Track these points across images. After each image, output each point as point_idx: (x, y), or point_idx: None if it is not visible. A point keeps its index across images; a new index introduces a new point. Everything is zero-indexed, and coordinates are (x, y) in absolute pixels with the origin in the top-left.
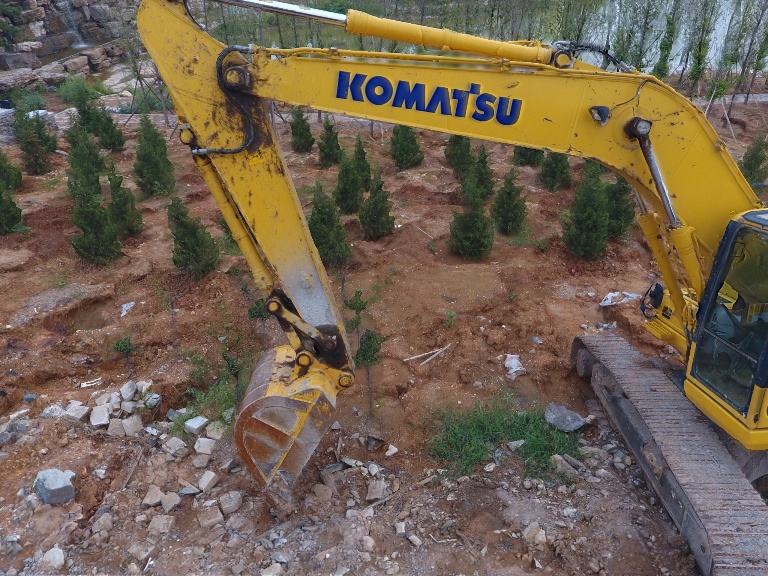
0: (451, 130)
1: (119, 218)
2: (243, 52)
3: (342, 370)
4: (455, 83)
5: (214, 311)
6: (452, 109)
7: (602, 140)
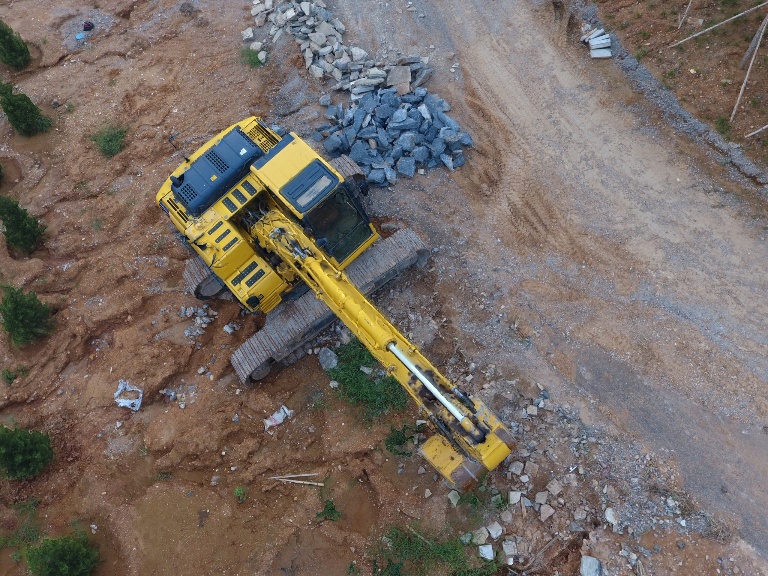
0: None
1: None
2: (439, 421)
3: None
4: None
5: None
6: None
7: None
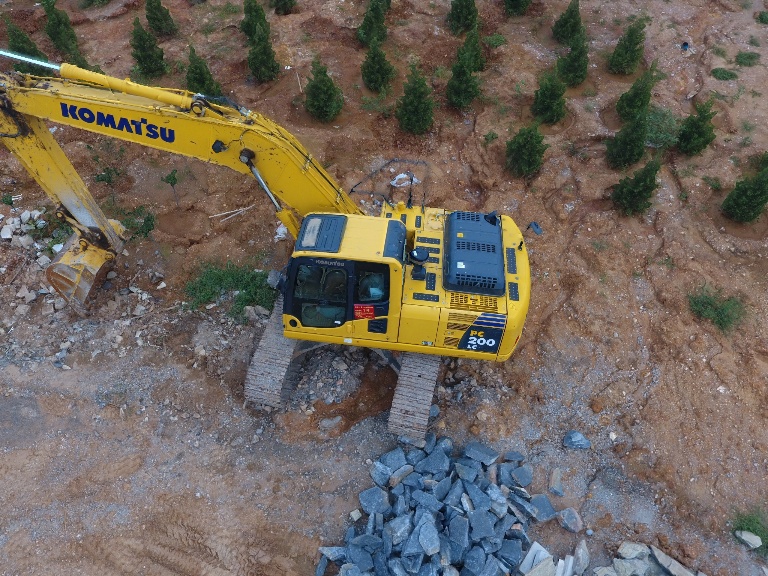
0: (136, 141)
1: (56, 37)
2: None
3: (107, 250)
4: (131, 116)
5: (107, 147)
6: (133, 130)
7: (229, 157)
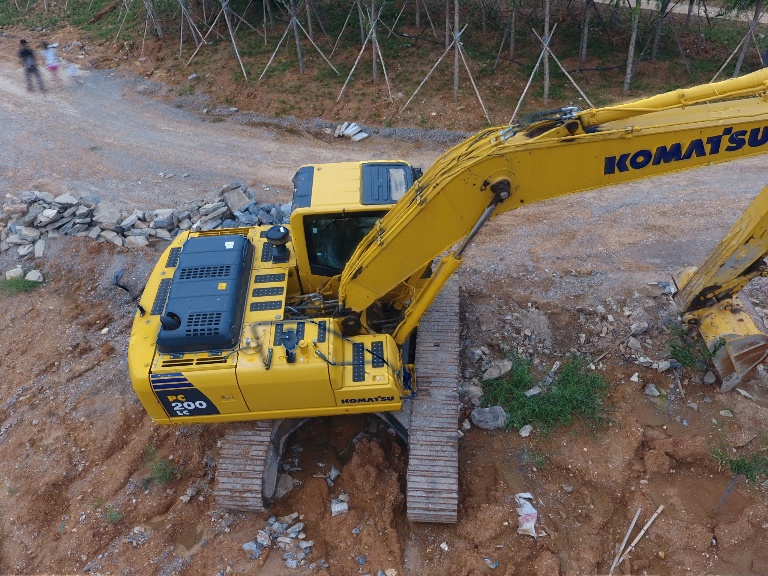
0: None
1: None
2: None
3: None
4: None
5: None
6: None
7: None
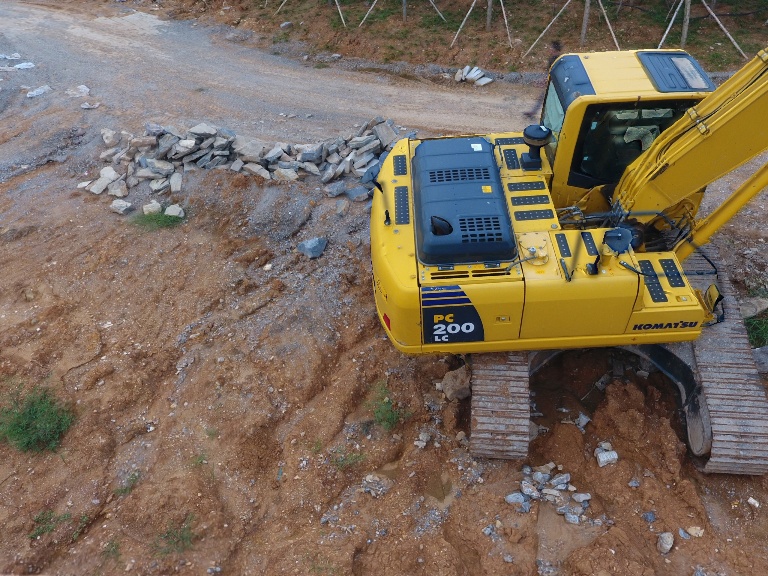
0: None
1: None
2: None
3: None
4: None
5: None
6: None
7: None
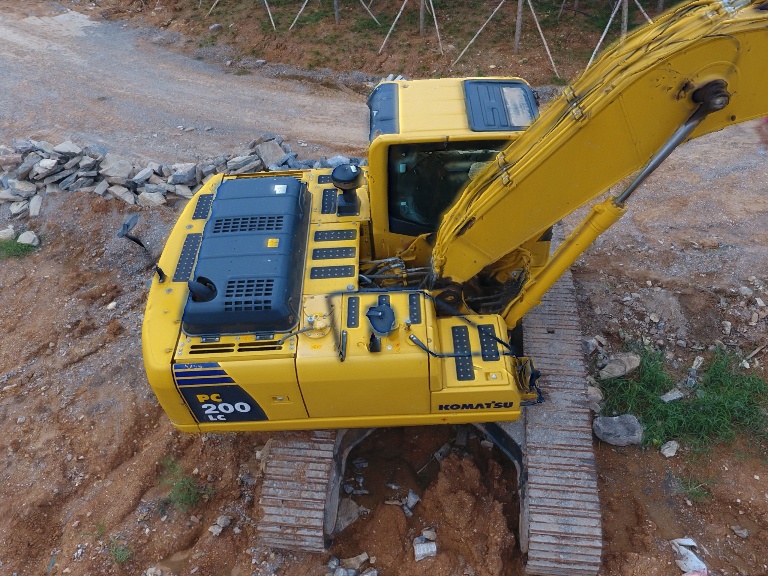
0: None
1: None
2: None
3: None
4: None
5: None
6: None
7: None
